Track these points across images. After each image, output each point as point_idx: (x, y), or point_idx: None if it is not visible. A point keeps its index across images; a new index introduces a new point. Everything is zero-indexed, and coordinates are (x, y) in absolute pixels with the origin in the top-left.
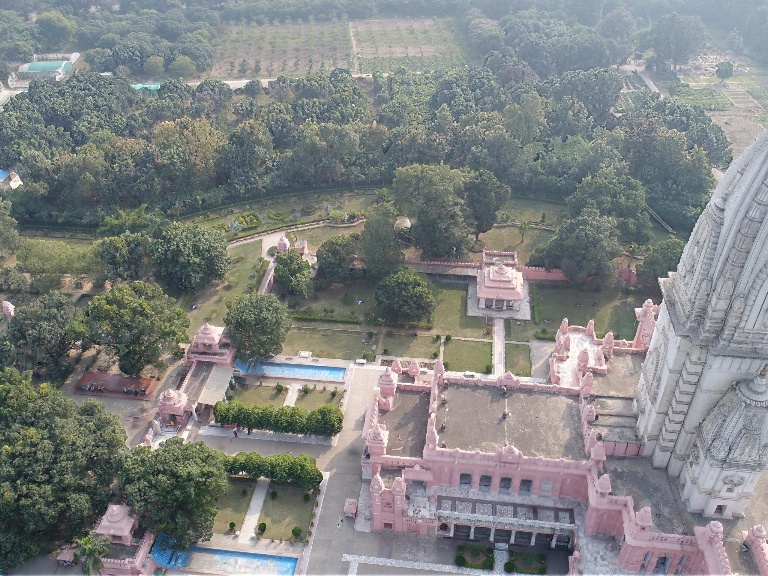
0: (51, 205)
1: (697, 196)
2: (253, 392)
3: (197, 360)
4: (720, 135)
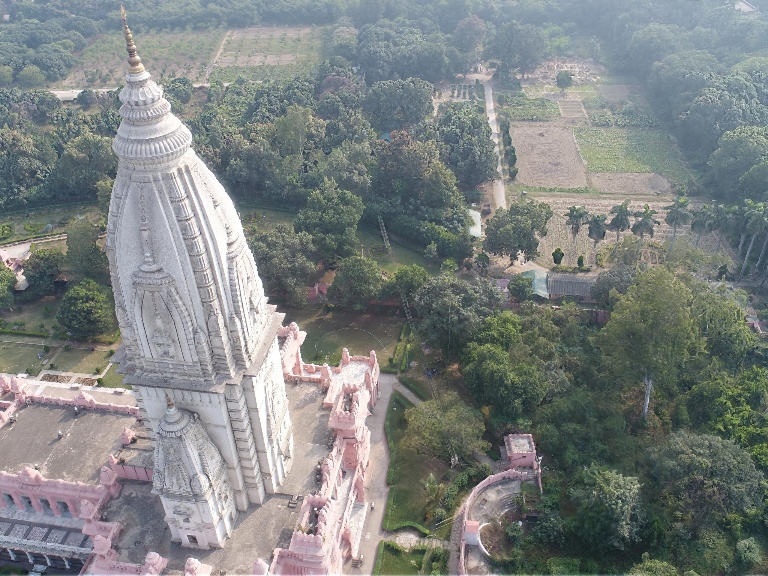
0: None
1: (437, 211)
2: None
3: None
4: (484, 148)
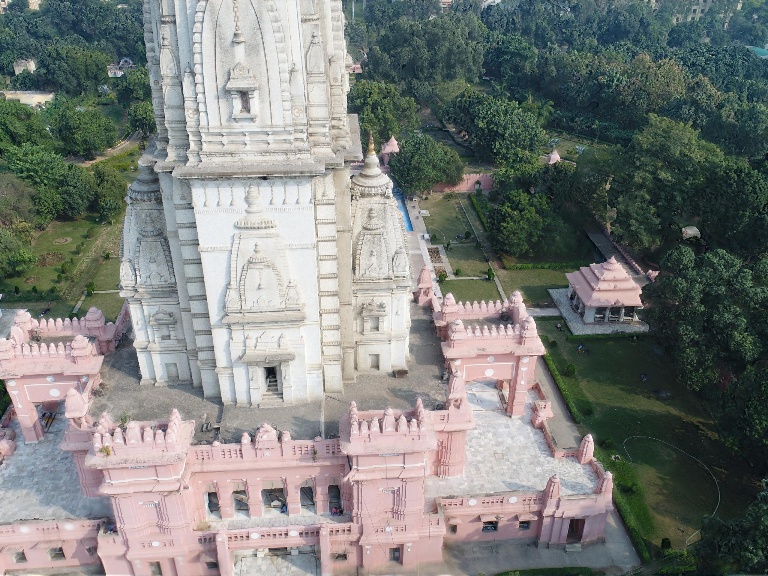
0: (536, 91)
1: None
2: None
3: None
4: None
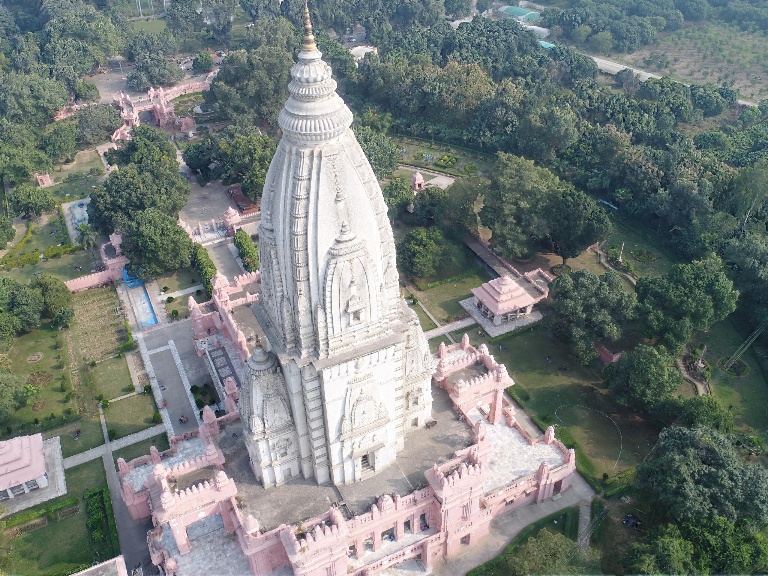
0: (364, 94)
1: None
2: None
3: None
4: None
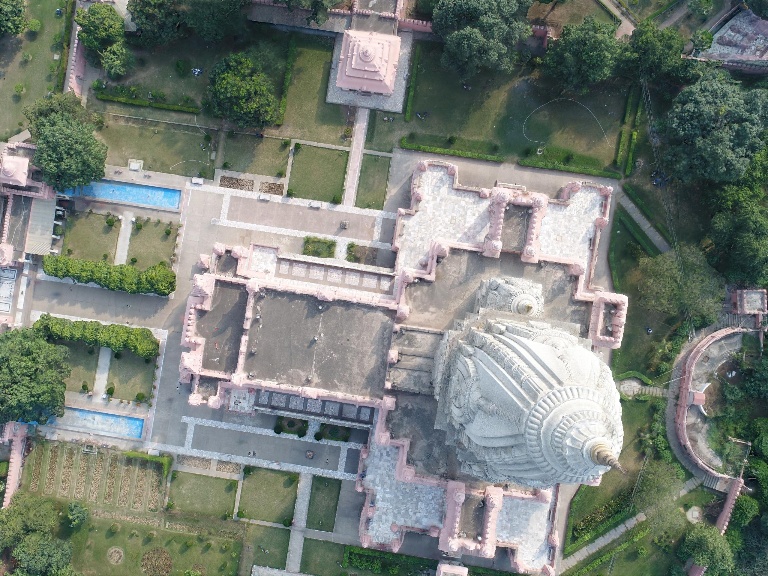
0: None
1: None
2: (84, 222)
3: (12, 194)
4: None
